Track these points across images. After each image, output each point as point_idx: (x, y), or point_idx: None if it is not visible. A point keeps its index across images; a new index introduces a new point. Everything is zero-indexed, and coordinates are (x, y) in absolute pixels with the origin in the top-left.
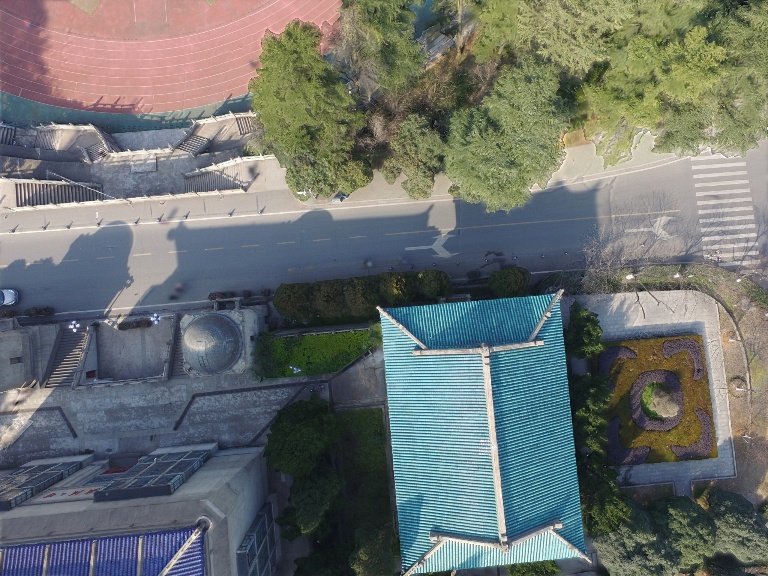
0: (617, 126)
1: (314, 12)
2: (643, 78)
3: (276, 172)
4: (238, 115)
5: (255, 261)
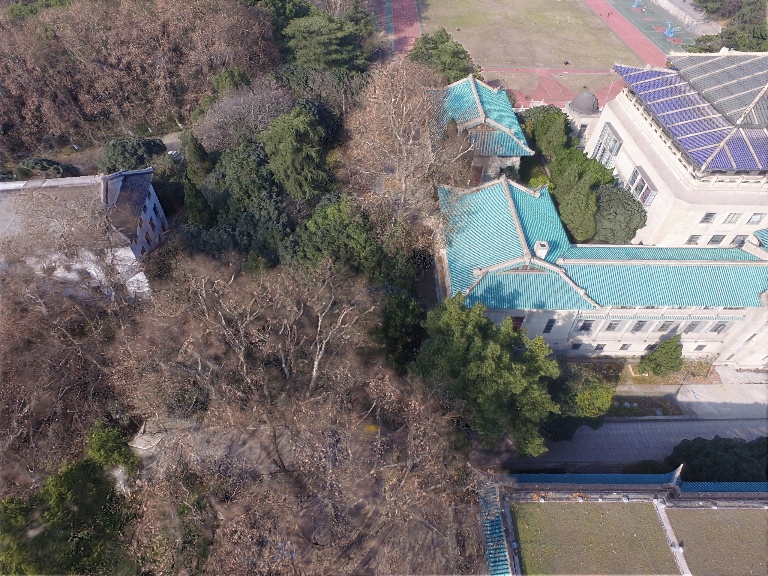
0: None
1: None
2: None
3: None
4: None
5: None
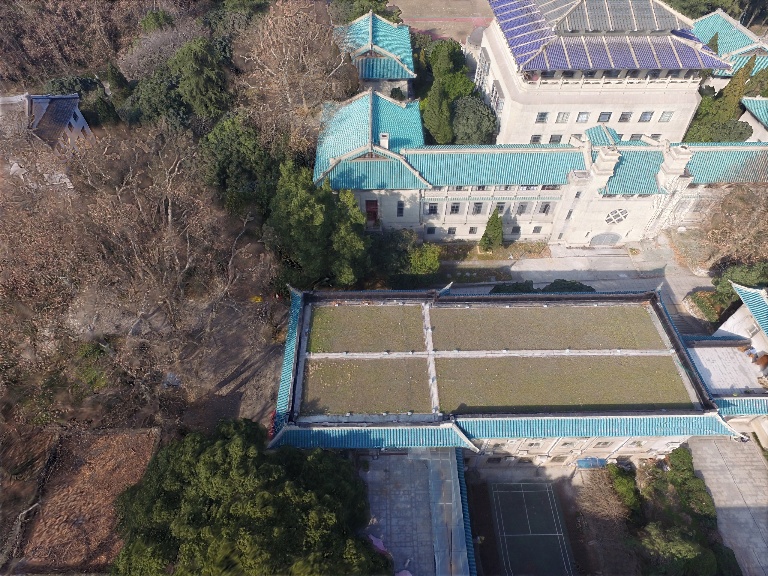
0: (731, 7)
1: None
2: None
3: None
4: None
5: None
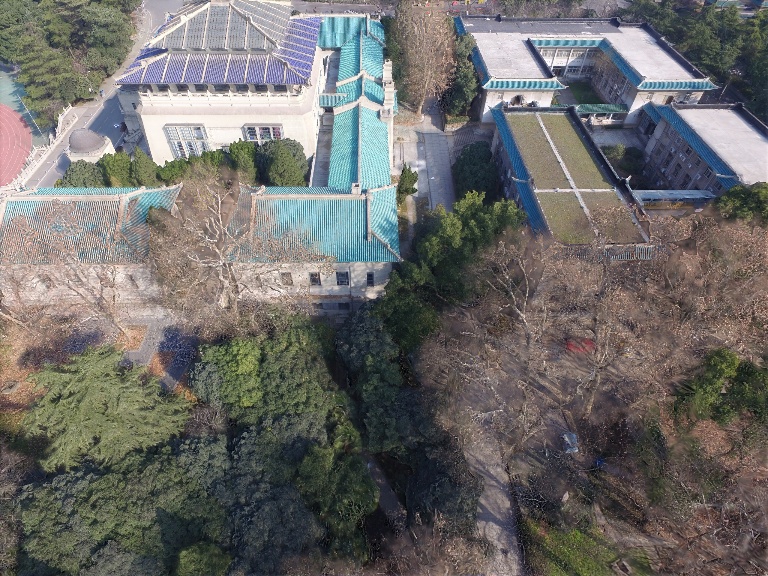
0: None
1: (5, 137)
2: (103, 1)
3: (76, 111)
4: (37, 149)
5: (115, 119)
